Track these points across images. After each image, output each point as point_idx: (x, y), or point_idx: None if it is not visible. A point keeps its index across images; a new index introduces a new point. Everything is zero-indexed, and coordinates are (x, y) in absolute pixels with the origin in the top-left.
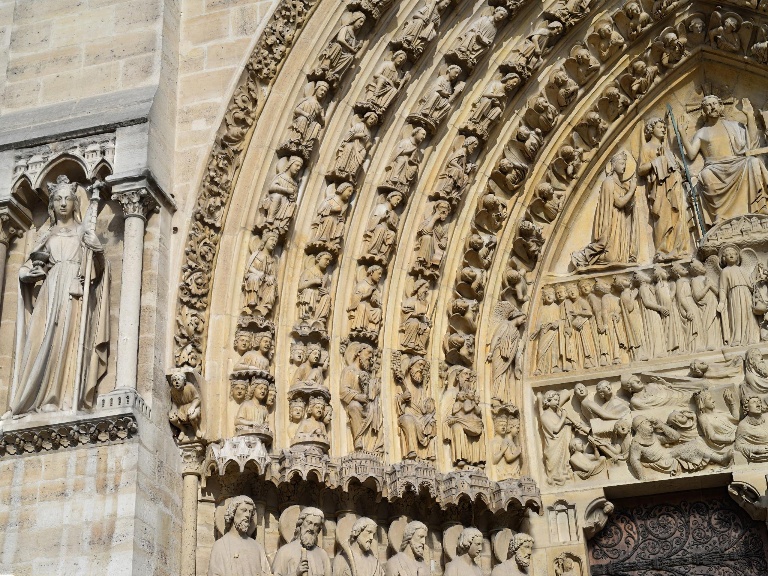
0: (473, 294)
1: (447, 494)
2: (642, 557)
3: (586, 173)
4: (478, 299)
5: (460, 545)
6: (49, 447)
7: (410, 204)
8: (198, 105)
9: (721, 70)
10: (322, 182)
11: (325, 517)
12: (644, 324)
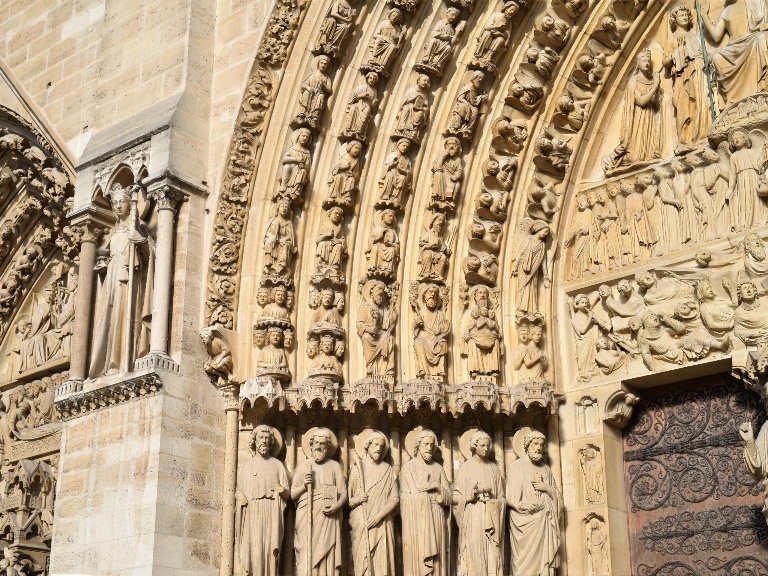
0: (495, 216)
1: (456, 404)
2: (668, 442)
3: (614, 76)
4: (501, 220)
5: (469, 447)
6: (114, 402)
7: (425, 145)
8: (225, 99)
9: None
10: (335, 144)
11: (353, 433)
12: (662, 219)
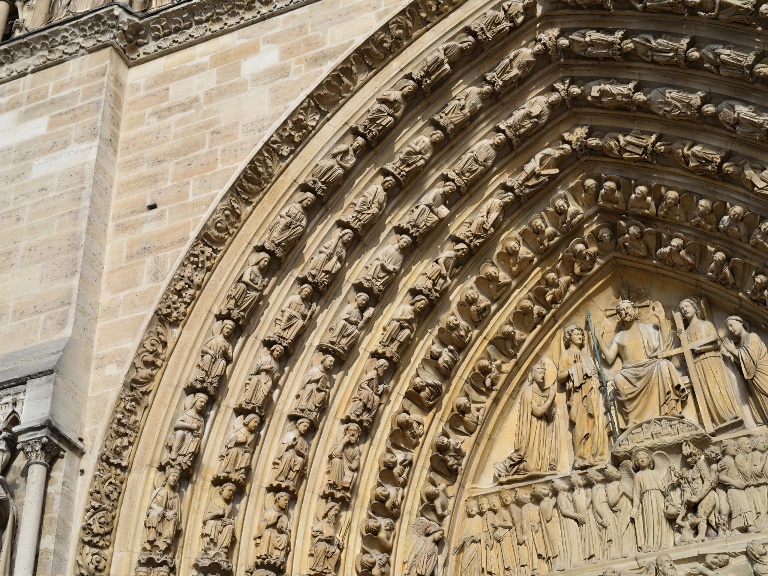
0: (389, 512)
1: None
2: None
3: (507, 384)
4: (394, 517)
5: None
6: None
7: (322, 429)
8: (111, 351)
9: (635, 274)
10: (230, 415)
11: None
12: (562, 533)
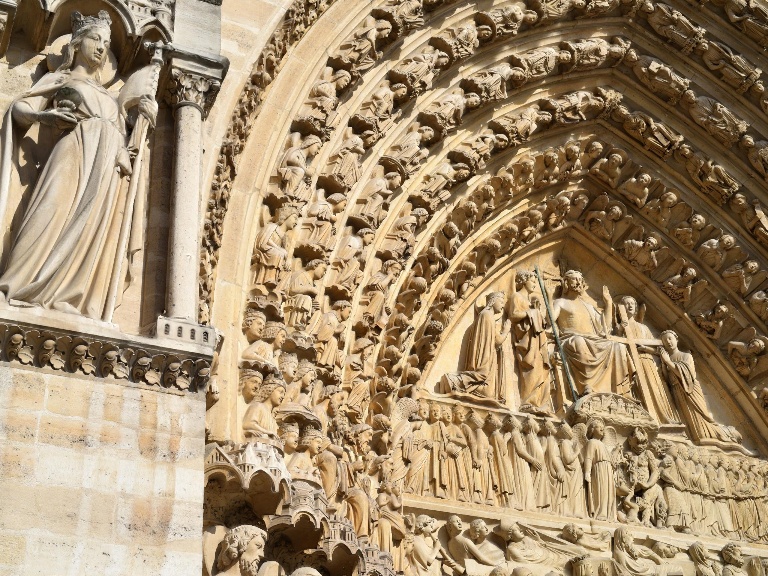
0: None
1: None
2: None
3: None
4: None
5: None
6: (59, 365)
7: None
8: (228, 23)
9: (581, 252)
10: (316, 181)
11: None
12: (516, 472)
